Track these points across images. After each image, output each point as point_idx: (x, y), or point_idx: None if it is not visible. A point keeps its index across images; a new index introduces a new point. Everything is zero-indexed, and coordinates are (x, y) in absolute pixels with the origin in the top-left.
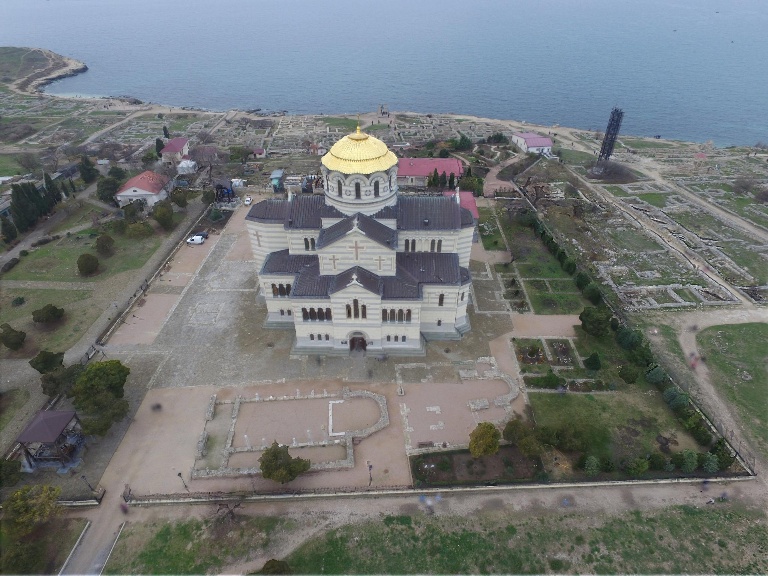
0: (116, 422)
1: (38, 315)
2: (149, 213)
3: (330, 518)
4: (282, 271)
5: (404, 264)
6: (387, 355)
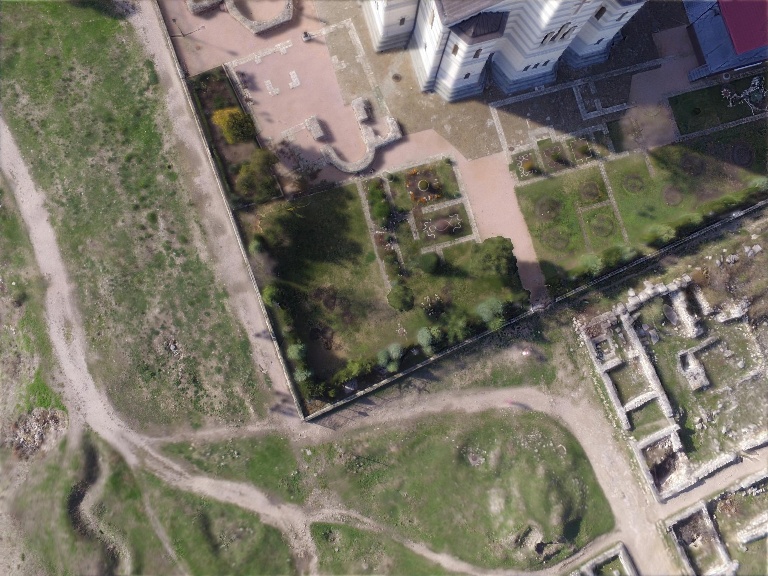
0: None
1: None
2: None
3: (135, 11)
4: None
5: None
6: (361, 3)
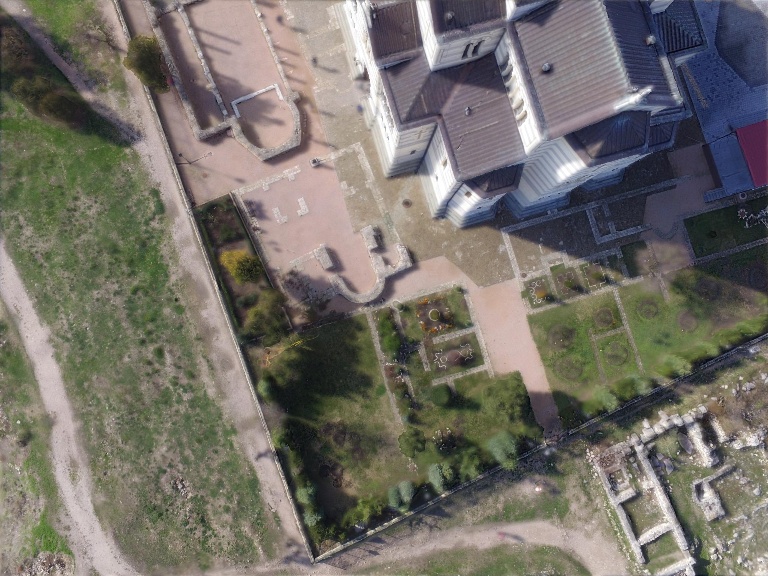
0: None
1: None
2: None
3: (140, 138)
4: None
5: (474, 77)
6: (370, 127)
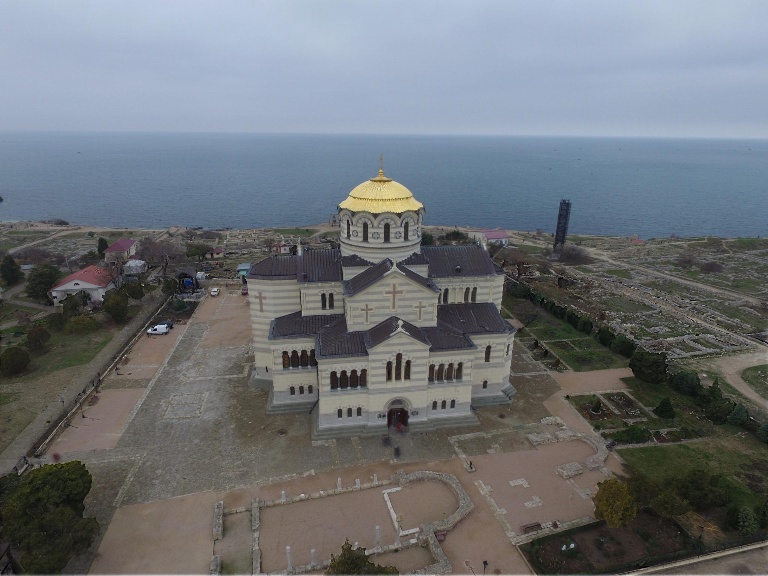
0: (76, 555)
1: None
2: (94, 308)
3: None
4: (297, 333)
5: (439, 316)
6: (435, 427)
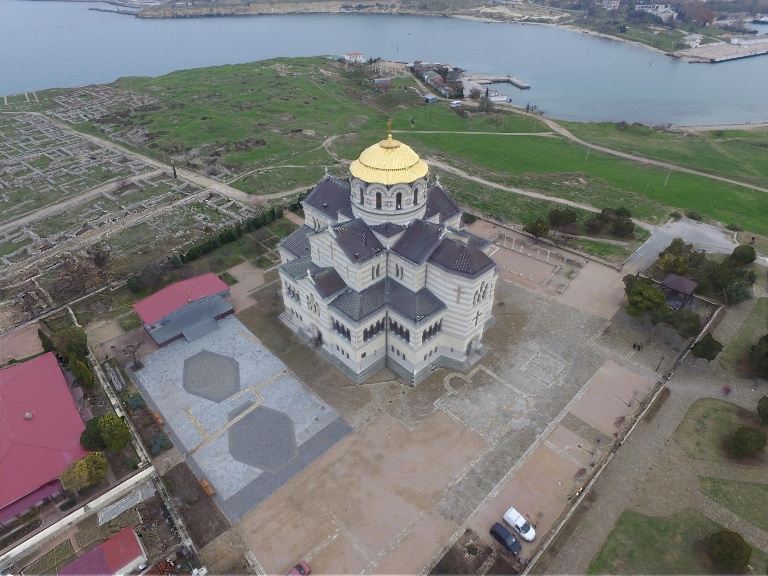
0: None
1: (756, 428)
2: None
3: None
4: None
5: None
6: None
